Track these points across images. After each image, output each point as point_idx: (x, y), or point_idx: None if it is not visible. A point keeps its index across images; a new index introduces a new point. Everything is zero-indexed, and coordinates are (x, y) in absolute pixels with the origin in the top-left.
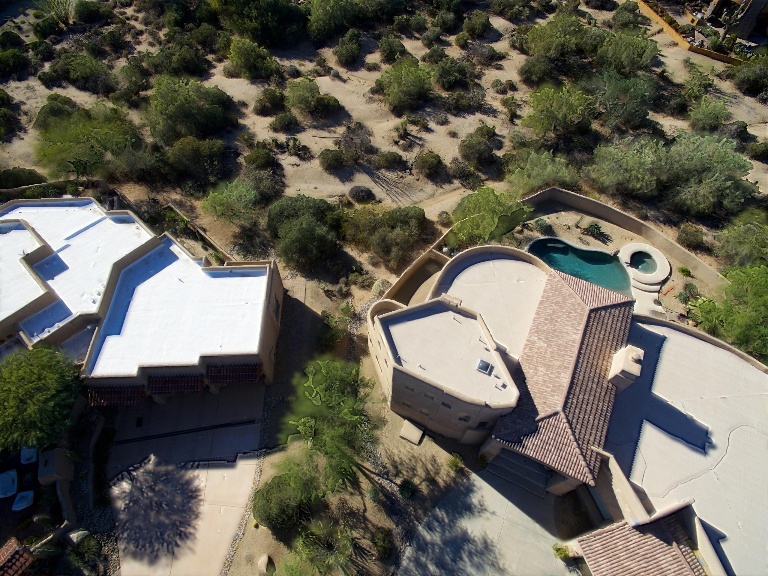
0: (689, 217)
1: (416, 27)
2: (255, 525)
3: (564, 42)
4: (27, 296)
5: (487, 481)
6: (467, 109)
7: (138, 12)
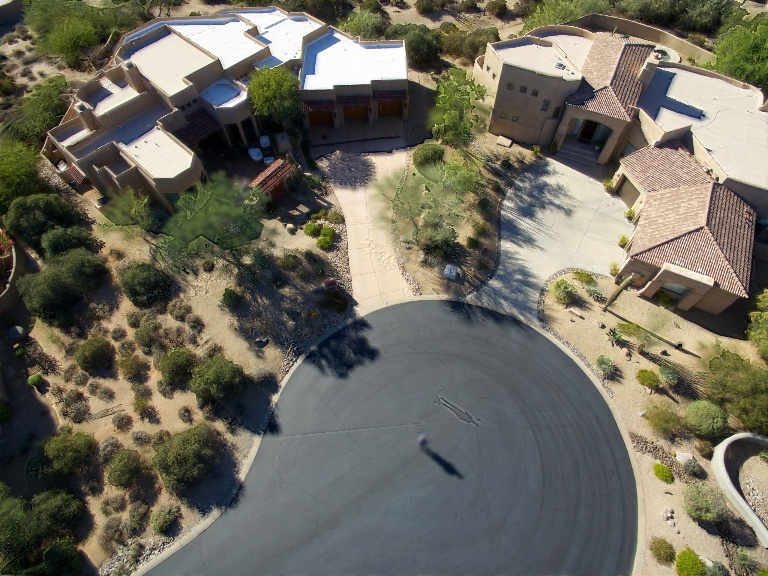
0: (695, 33)
1: None
2: (413, 173)
3: None
4: (254, 51)
5: (557, 160)
6: None
7: None
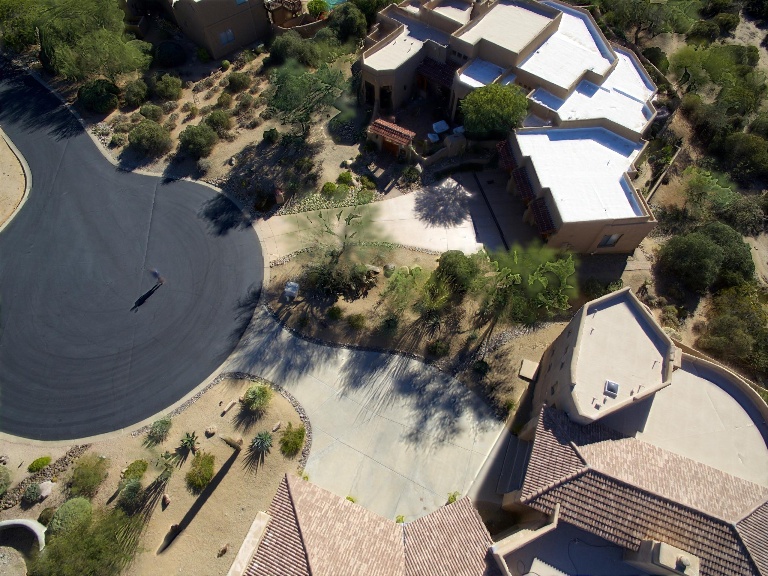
0: None
1: None
2: None
3: None
4: (561, 83)
5: (501, 436)
6: None
7: None
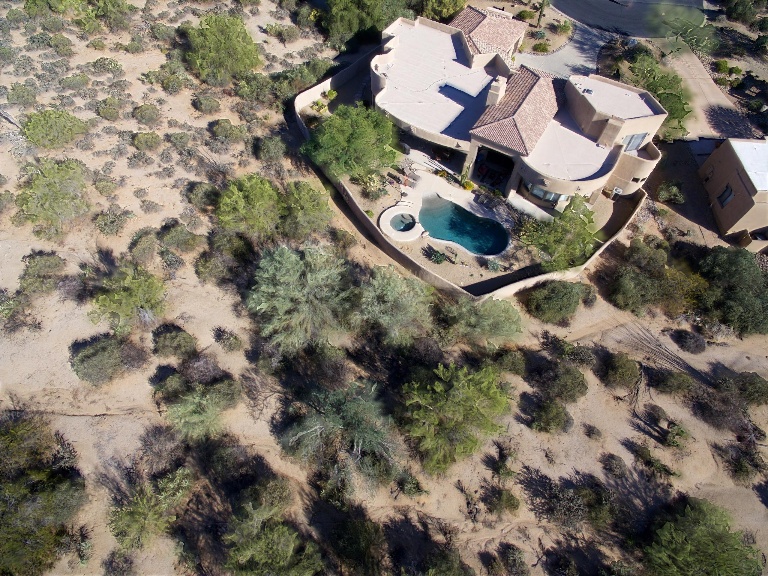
0: None
1: None
2: None
3: None
4: None
5: None
6: None
7: None
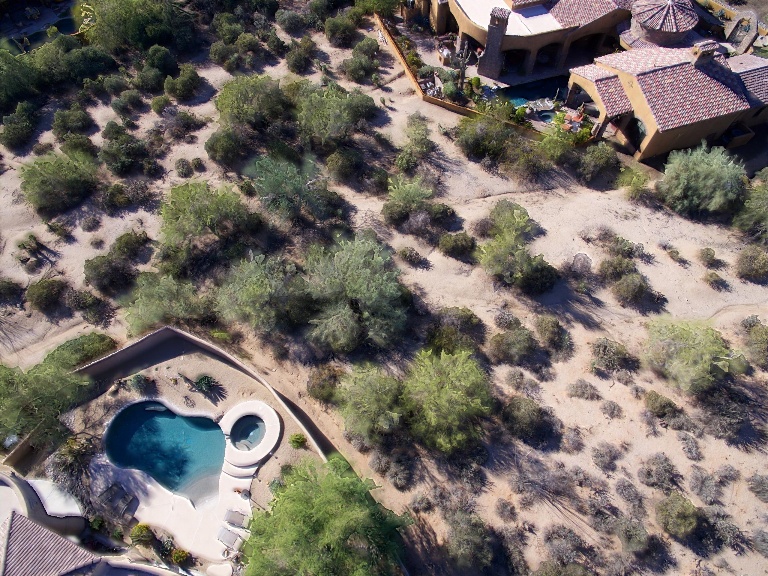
0: None
1: (110, 90)
2: None
3: (239, 114)
4: None
5: None
6: (129, 205)
7: None
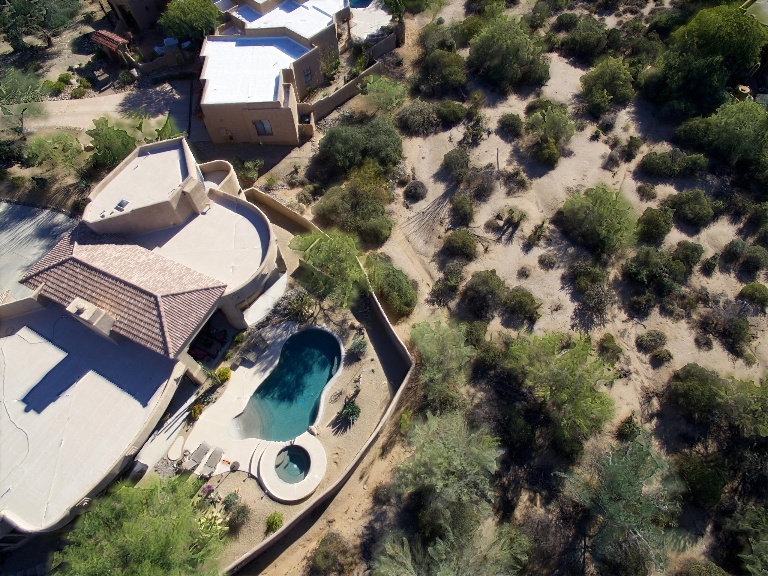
0: None
1: (761, 232)
2: None
3: (752, 411)
4: (263, 0)
5: None
6: None
7: (672, 3)
